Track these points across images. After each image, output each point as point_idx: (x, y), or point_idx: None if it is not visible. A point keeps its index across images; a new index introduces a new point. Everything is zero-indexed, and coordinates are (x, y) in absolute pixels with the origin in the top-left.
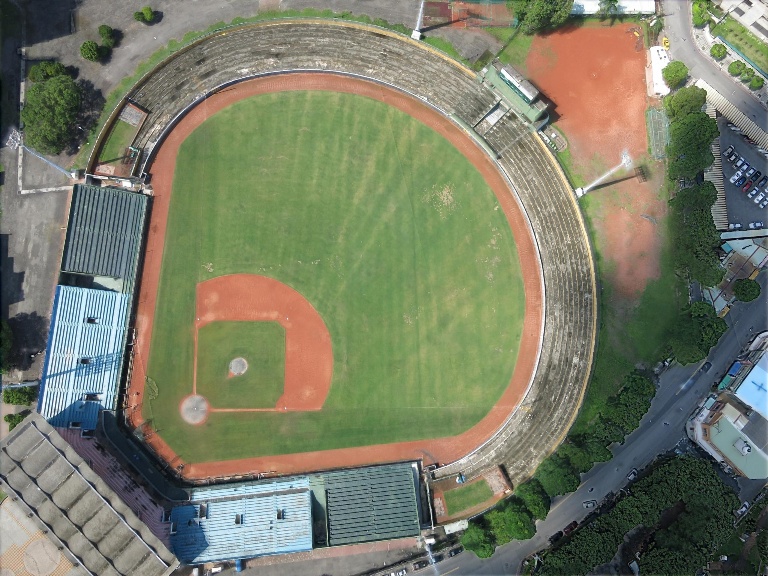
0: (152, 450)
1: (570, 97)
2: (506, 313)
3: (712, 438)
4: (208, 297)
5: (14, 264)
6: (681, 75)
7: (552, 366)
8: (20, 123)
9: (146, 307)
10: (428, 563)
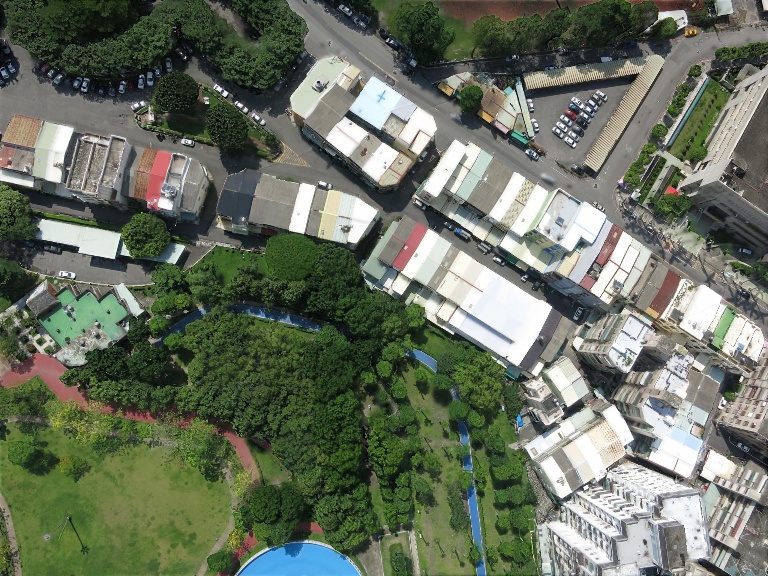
0: None
1: None
2: None
3: (325, 59)
4: None
5: None
6: (665, 28)
7: None
8: None
9: None
10: None
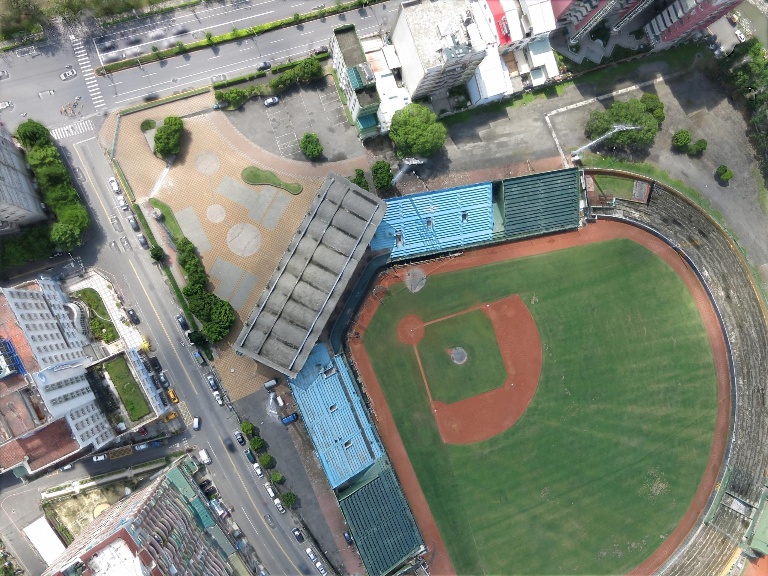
0: (365, 304)
1: None
2: None
3: None
4: (509, 307)
5: (486, 130)
6: None
7: None
8: (602, 96)
9: (484, 256)
10: None
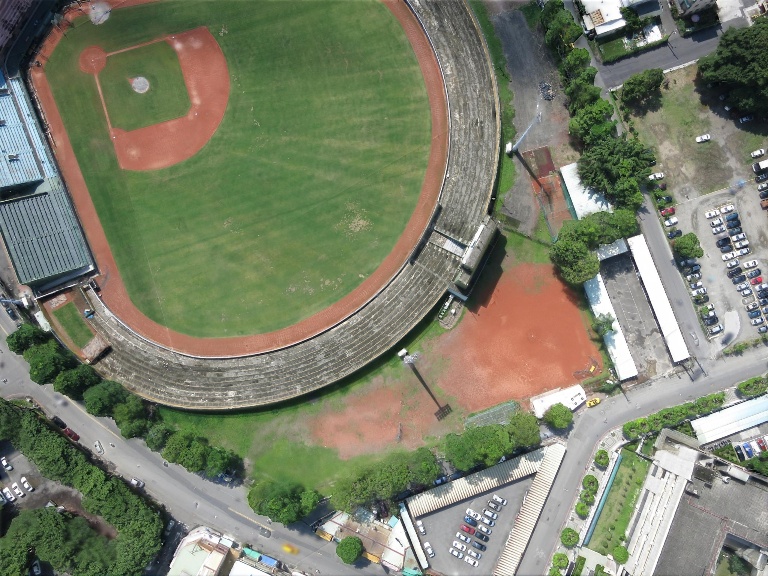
0: (48, 36)
1: (500, 318)
2: (261, 315)
3: (185, 548)
4: (196, 39)
5: None
6: (557, 421)
7: (220, 373)
8: None
9: None
10: (7, 307)
